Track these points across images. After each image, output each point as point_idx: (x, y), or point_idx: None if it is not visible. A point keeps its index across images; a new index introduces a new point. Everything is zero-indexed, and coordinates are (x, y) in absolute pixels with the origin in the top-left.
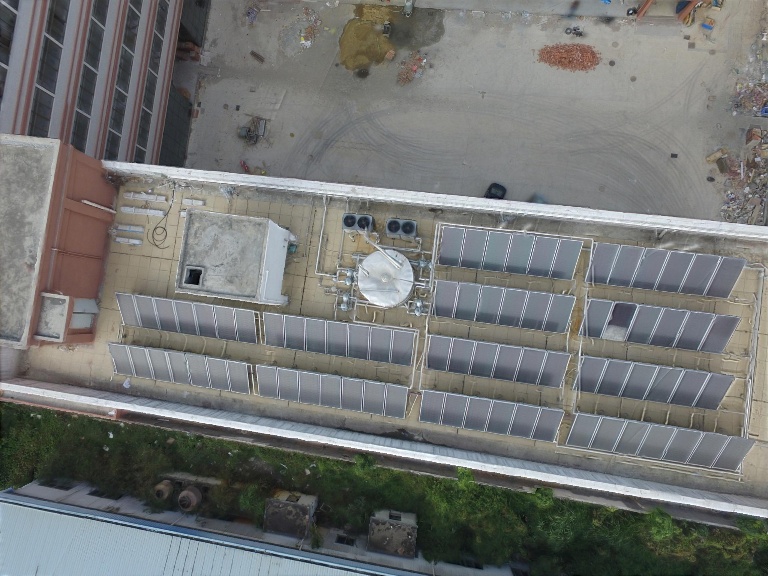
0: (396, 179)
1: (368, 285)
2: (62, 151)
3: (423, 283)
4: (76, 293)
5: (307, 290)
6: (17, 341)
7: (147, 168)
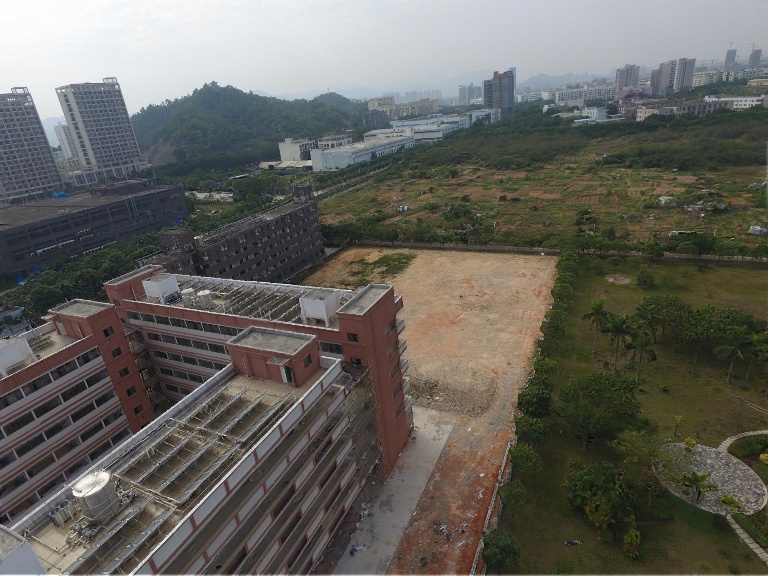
0: None
1: None
2: (85, 319)
3: None
4: (65, 328)
5: None
6: (52, 310)
7: (74, 343)
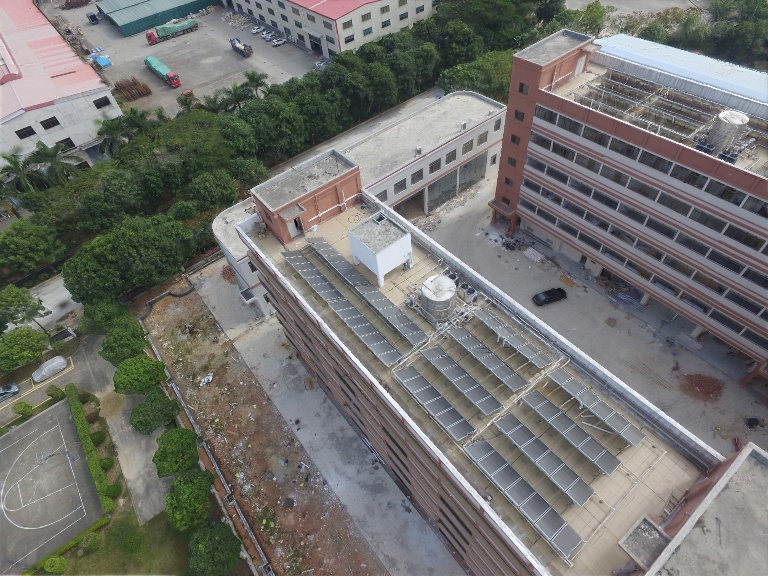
0: (601, 351)
1: (744, 118)
2: None
3: (715, 114)
4: None
5: (767, 159)
6: None
7: None
